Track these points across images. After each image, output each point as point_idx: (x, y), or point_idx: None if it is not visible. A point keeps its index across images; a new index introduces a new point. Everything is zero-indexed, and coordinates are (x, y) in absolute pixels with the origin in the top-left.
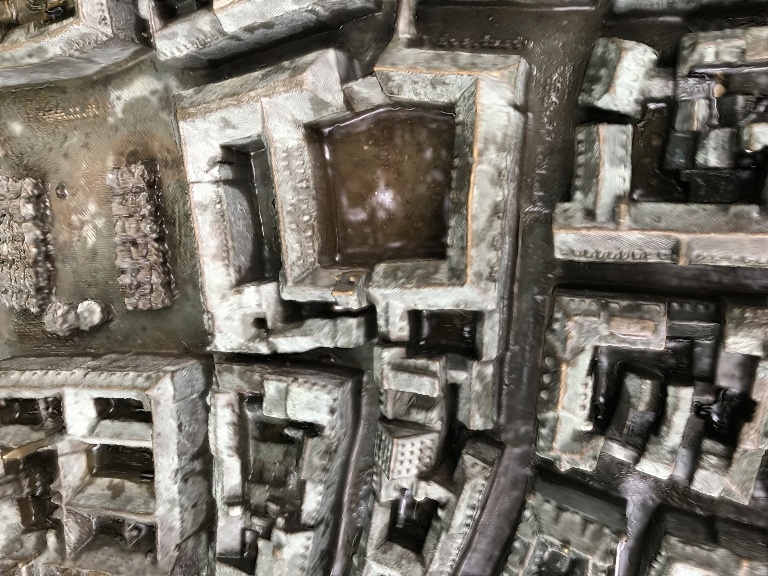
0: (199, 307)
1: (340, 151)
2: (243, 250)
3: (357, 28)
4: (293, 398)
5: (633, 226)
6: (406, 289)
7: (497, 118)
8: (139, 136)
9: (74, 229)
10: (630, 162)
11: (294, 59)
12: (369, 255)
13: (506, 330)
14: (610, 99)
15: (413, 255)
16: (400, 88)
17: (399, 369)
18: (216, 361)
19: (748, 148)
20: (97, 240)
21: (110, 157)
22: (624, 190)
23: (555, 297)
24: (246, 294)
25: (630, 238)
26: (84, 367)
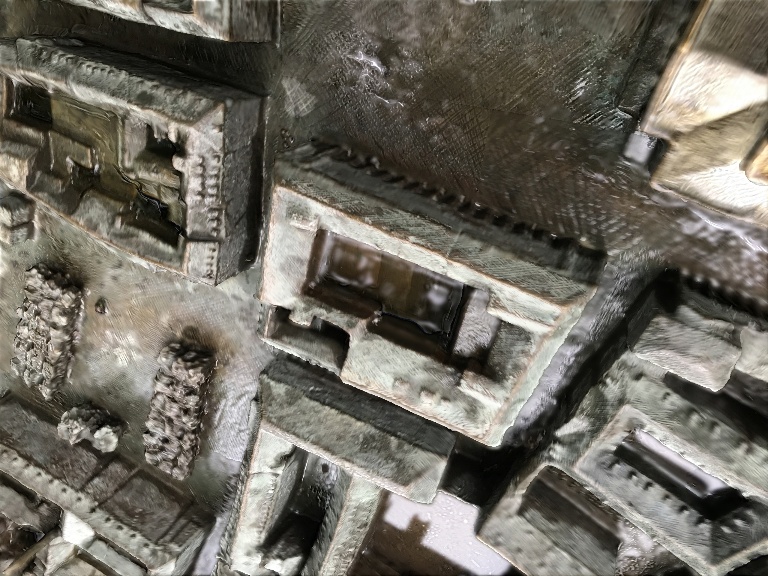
0: (216, 480)
1: None
2: (279, 509)
3: None
4: None
5: None
6: None
7: None
8: (205, 321)
9: (106, 342)
10: None
11: (403, 442)
12: (393, 557)
13: None
14: None
15: None
16: None
17: None
18: (218, 524)
19: None
20: (129, 367)
21: (166, 315)
22: None
23: None
24: (270, 564)
25: None
26: (91, 493)
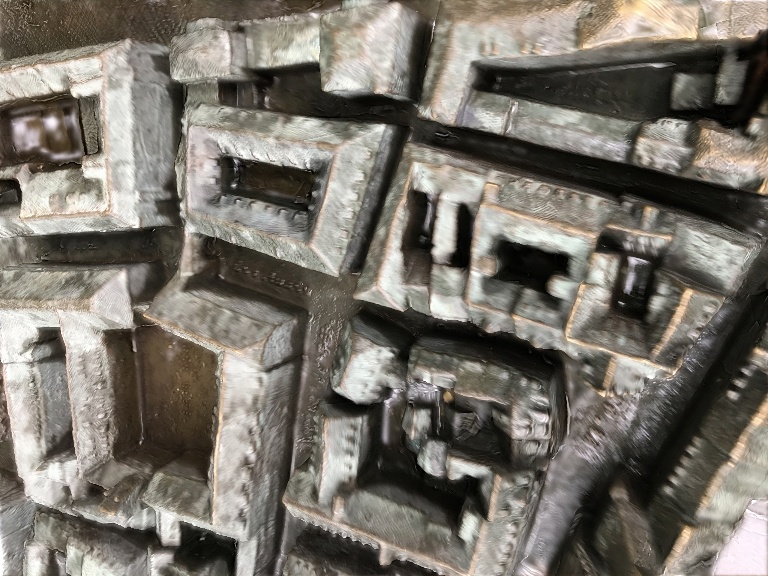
0: None
1: (150, 343)
2: (60, 419)
3: (168, 234)
4: (86, 569)
5: (345, 519)
6: (169, 511)
7: (247, 383)
8: None
9: None
10: (359, 450)
11: (93, 271)
12: (171, 442)
13: (273, 545)
14: (343, 391)
15: (199, 460)
16: (172, 331)
17: (165, 574)
18: None
19: (447, 476)
20: None
21: None
22: (351, 475)
23: (288, 553)
24: (51, 470)
25: (343, 528)
26: None
